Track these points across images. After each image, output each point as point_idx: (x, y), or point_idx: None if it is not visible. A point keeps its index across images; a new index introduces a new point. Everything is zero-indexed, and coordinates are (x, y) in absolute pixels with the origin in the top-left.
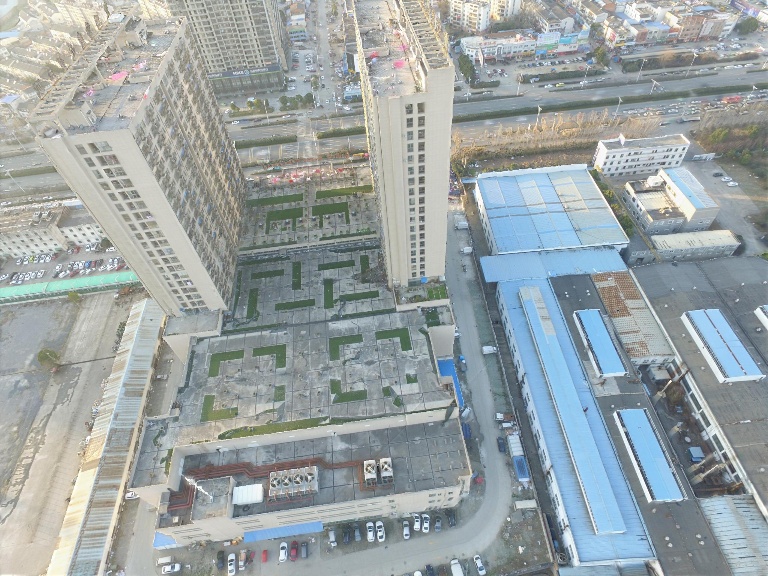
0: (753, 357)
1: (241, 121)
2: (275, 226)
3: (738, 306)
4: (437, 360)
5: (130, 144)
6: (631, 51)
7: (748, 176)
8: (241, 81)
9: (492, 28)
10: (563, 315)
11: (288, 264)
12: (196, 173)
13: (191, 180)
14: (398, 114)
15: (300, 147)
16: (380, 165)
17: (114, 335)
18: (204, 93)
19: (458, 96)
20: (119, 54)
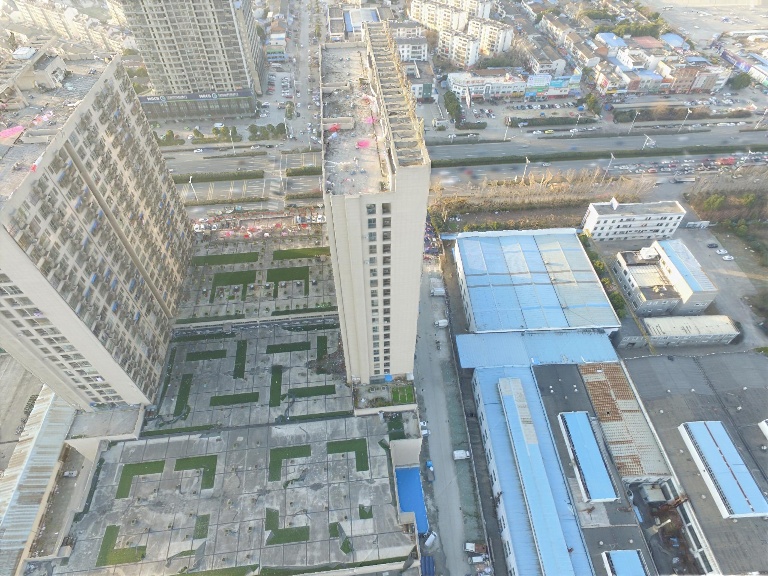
0: (760, 487)
1: (204, 149)
2: (222, 293)
3: (740, 415)
4: (400, 468)
5: (0, 236)
6: (623, 99)
7: (744, 249)
8: (208, 105)
9: (481, 64)
10: (547, 416)
11: (232, 343)
12: (115, 246)
13: (106, 257)
14: (357, 215)
15: (266, 185)
16: (335, 265)
17: (22, 411)
18: (139, 141)
19: (442, 137)
20: (20, 100)
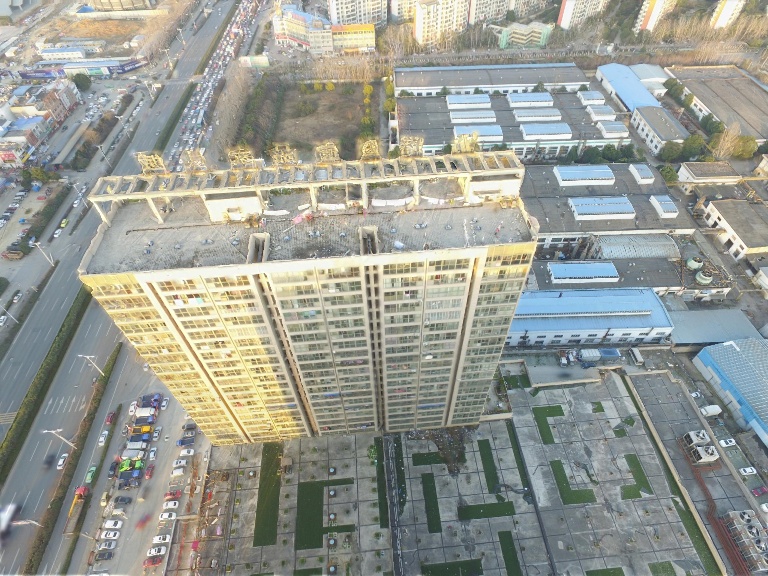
0: None
1: None
2: None
3: None
4: None
5: None
6: None
7: None
8: None
9: None
10: None
11: None
12: None
13: None
14: None
15: None
16: None
17: None
18: None
19: (3, 331)
20: None
